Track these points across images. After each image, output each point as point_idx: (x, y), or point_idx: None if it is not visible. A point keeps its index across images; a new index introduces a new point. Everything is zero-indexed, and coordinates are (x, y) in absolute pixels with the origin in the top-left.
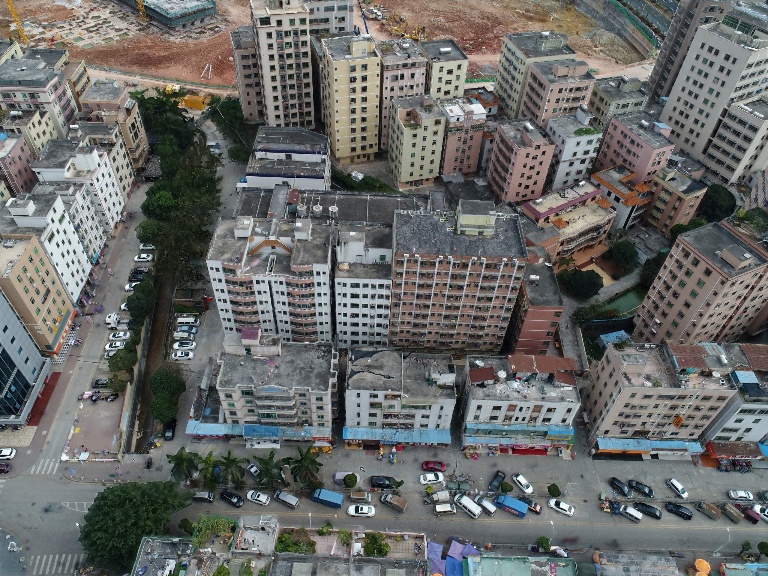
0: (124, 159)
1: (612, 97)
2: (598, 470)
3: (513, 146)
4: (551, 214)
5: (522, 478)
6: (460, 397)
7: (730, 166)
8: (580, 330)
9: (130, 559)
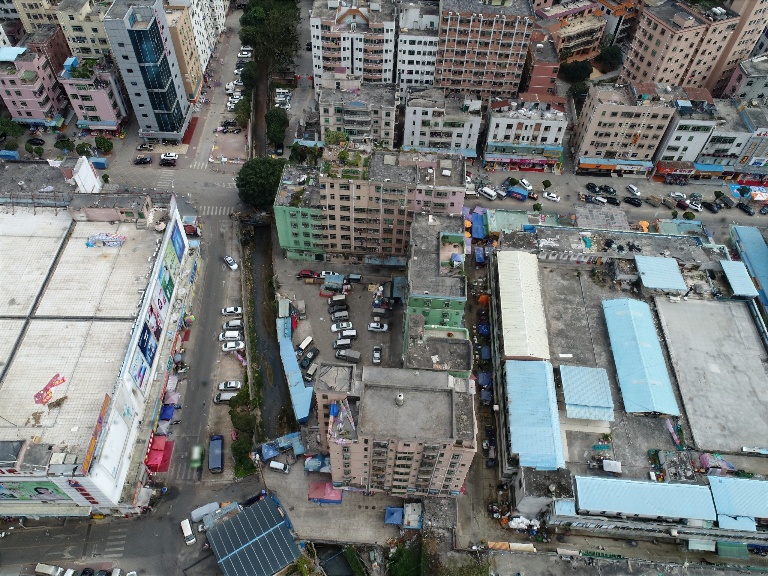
0: None
1: None
2: (579, 181)
3: None
4: (556, 18)
5: (525, 180)
6: (483, 132)
7: None
8: (573, 100)
9: (270, 196)
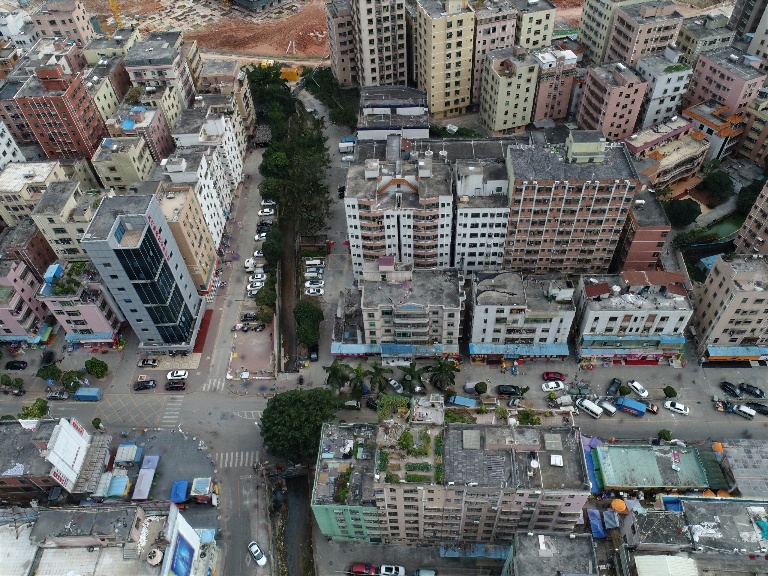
0: (240, 126)
1: (699, 35)
2: (709, 376)
3: (606, 86)
4: (647, 148)
5: (637, 384)
6: None
7: None
8: (681, 254)
9: (304, 449)
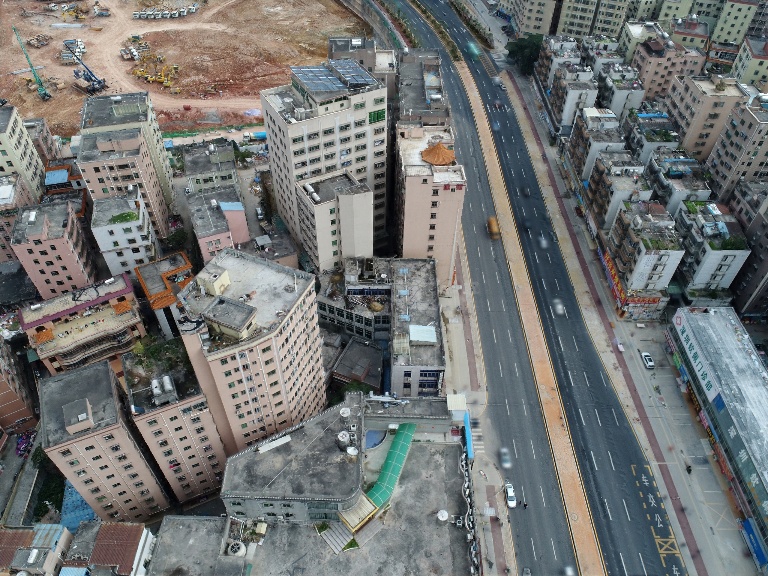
0: None
1: (194, 170)
2: None
3: None
4: (43, 324)
5: None
6: None
7: (314, 252)
8: (36, 473)
9: None
